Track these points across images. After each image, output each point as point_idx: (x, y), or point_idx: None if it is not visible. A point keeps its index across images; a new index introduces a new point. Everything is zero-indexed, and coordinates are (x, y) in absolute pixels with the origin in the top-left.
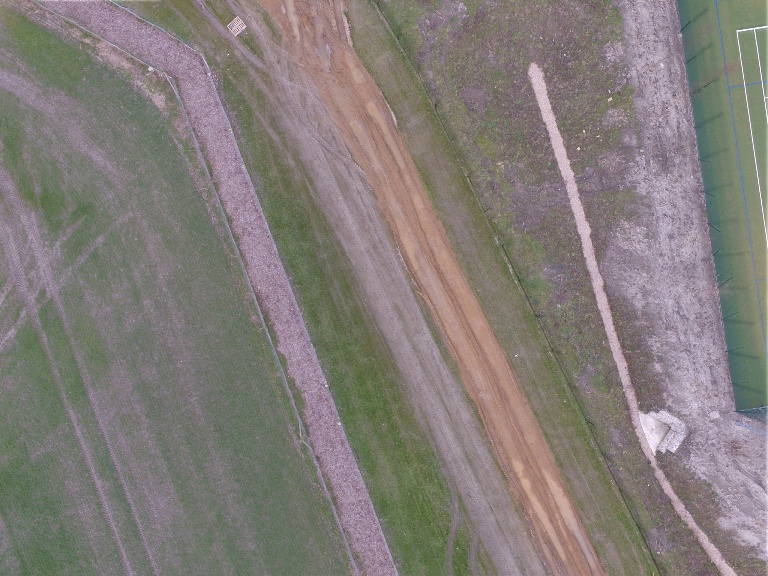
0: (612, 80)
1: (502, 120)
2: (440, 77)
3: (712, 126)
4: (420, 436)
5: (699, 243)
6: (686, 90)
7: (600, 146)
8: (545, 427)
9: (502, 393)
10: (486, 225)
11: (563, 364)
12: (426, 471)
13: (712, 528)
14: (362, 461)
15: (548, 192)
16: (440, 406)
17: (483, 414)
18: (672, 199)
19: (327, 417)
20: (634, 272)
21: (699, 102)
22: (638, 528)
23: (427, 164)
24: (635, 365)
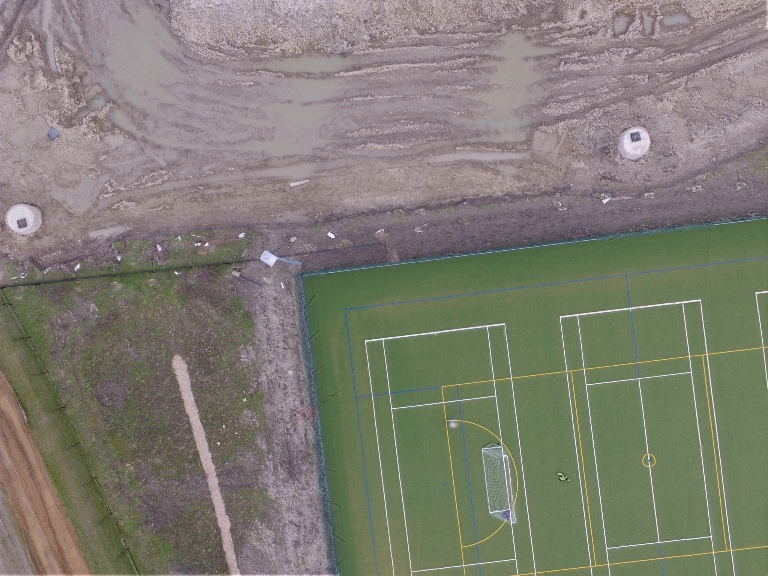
0: (247, 381)
1: (143, 412)
2: (71, 376)
3: (339, 435)
4: None
5: (324, 552)
6: (313, 399)
7: (239, 443)
8: None
9: None
10: (113, 526)
11: None
12: None
13: None
14: None
15: (188, 485)
16: None
17: None
18: (298, 507)
19: None
20: (263, 575)
21: (326, 411)
22: None
23: (57, 462)
24: None
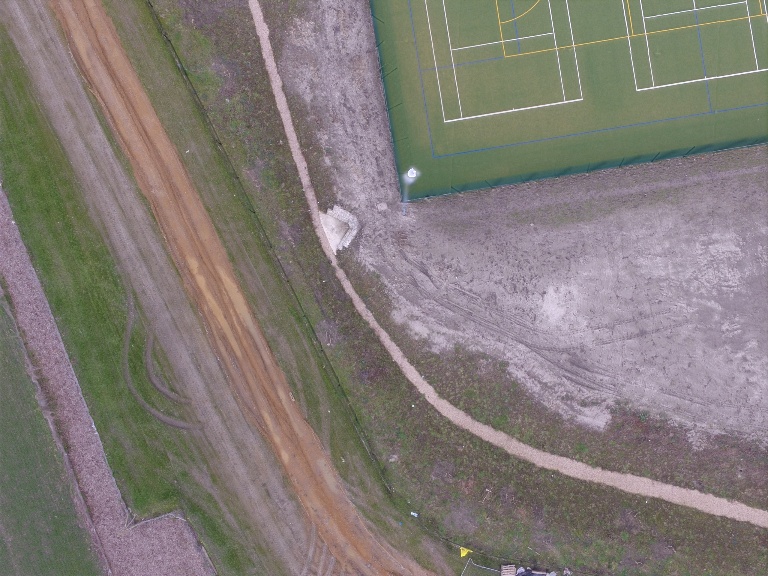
0: None
1: None
2: None
3: None
4: (94, 234)
5: (363, 35)
6: None
7: None
8: (217, 222)
9: (175, 189)
10: (154, 21)
11: (233, 158)
12: (101, 269)
13: (389, 324)
14: (37, 259)
15: None
16: (114, 204)
17: (156, 211)
18: None
19: (1, 216)
20: (304, 67)
21: None
22: (307, 320)
23: None
24: (311, 163)
